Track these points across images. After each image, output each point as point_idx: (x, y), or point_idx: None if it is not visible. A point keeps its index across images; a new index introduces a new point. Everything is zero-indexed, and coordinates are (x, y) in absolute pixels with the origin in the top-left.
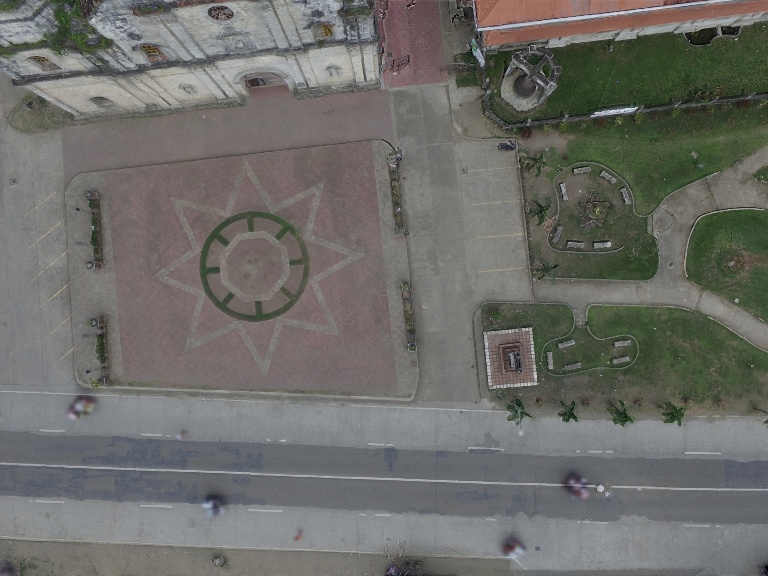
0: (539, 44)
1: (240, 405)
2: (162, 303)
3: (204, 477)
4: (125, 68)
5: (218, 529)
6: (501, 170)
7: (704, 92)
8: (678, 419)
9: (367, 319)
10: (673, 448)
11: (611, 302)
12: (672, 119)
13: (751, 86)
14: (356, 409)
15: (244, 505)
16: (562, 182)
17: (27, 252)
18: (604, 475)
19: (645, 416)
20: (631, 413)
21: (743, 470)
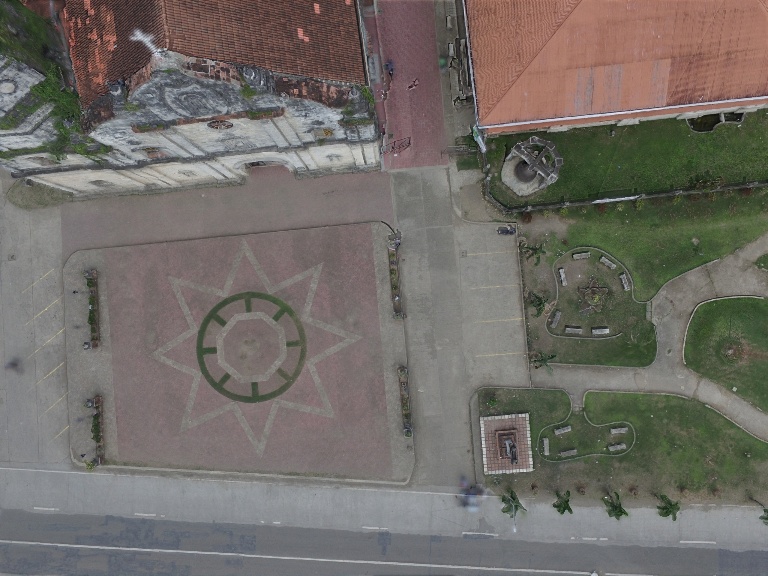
0: (541, 128)
1: (235, 486)
2: (158, 382)
3: (198, 558)
4: (124, 163)
5: None
6: (500, 254)
7: (706, 180)
8: (673, 514)
9: (363, 402)
10: (668, 536)
11: (608, 388)
12: (673, 205)
13: (753, 173)
14: (351, 492)
15: None
16: (561, 267)
17: (24, 328)
18: (598, 562)
19: (640, 504)
20: (626, 500)
21: (738, 560)
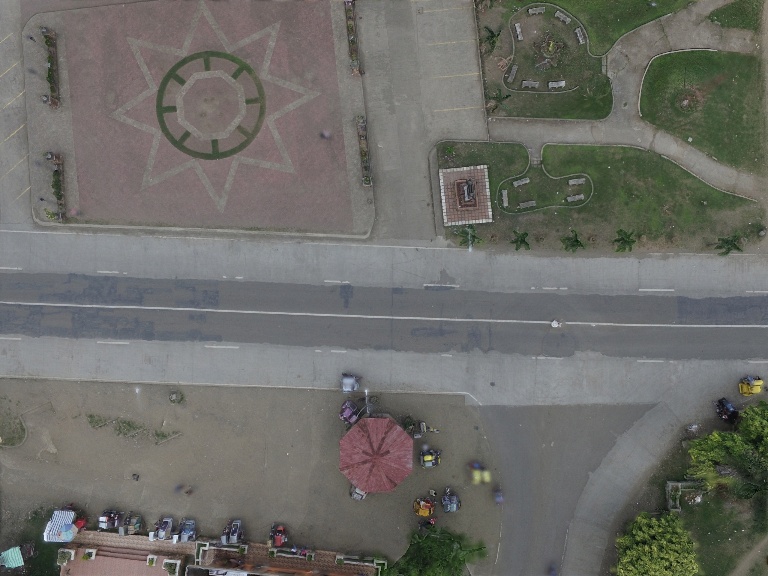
0: None
1: (197, 243)
2: (119, 142)
3: (161, 314)
4: None
5: (175, 365)
6: (456, 10)
7: None
8: (629, 244)
9: (323, 157)
10: (627, 285)
11: (566, 141)
12: None
13: None
14: (312, 246)
15: (201, 341)
16: (517, 23)
17: None
18: (559, 311)
19: (599, 253)
20: (585, 250)
21: (696, 306)
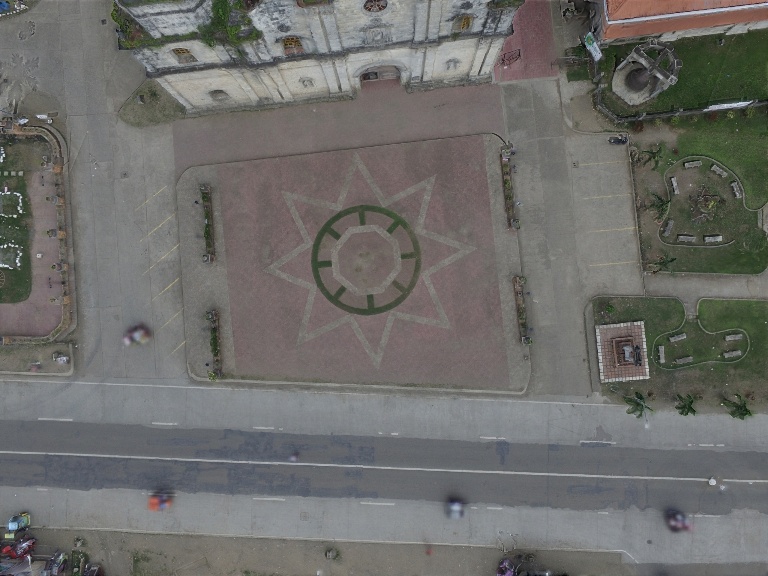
0: (650, 38)
1: (352, 398)
2: (274, 296)
3: (317, 470)
4: (260, 60)
5: (331, 522)
6: (612, 164)
7: None
8: None
9: (479, 313)
10: None
11: (722, 296)
12: None
13: None
14: (468, 402)
15: (356, 498)
16: (673, 176)
17: (138, 245)
18: (716, 469)
19: (756, 410)
20: None
21: None
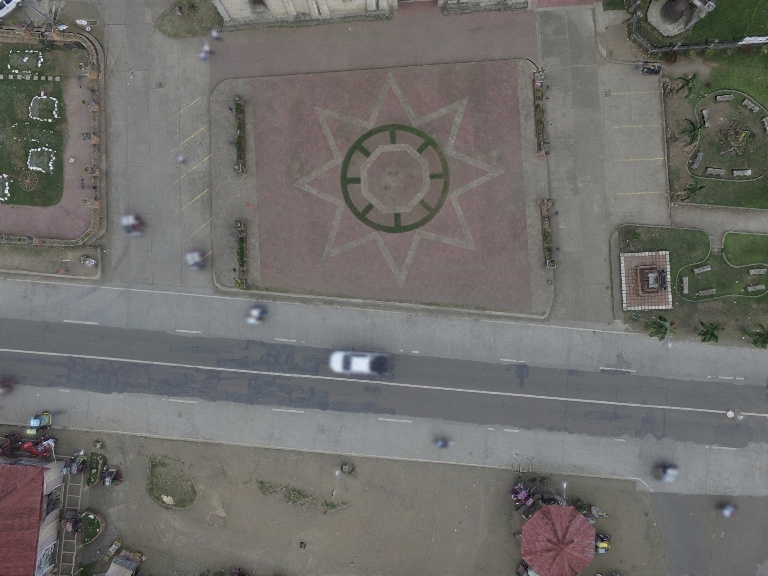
0: None
1: (375, 315)
2: (302, 210)
3: (336, 384)
4: None
5: (348, 436)
6: (644, 94)
7: None
8: None
9: (505, 235)
10: None
11: (748, 230)
12: None
13: None
14: (490, 324)
15: (375, 414)
16: (704, 109)
17: (170, 155)
18: (734, 401)
19: None
20: None
21: None
